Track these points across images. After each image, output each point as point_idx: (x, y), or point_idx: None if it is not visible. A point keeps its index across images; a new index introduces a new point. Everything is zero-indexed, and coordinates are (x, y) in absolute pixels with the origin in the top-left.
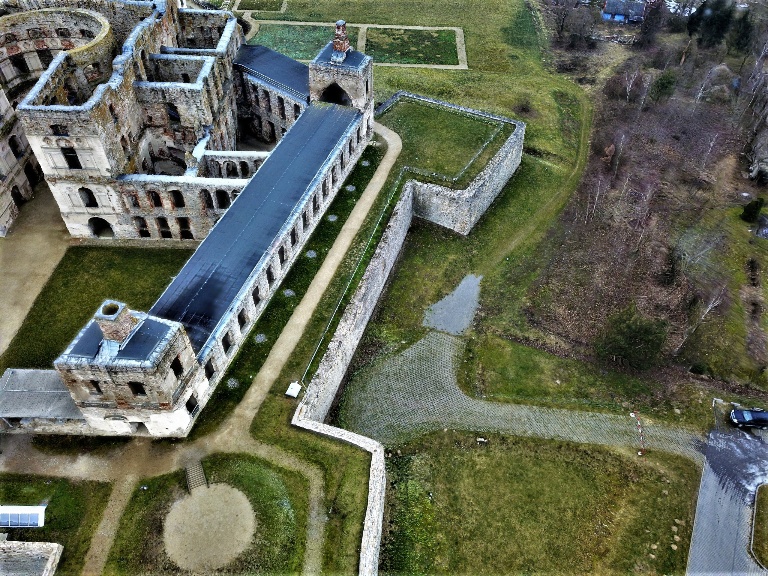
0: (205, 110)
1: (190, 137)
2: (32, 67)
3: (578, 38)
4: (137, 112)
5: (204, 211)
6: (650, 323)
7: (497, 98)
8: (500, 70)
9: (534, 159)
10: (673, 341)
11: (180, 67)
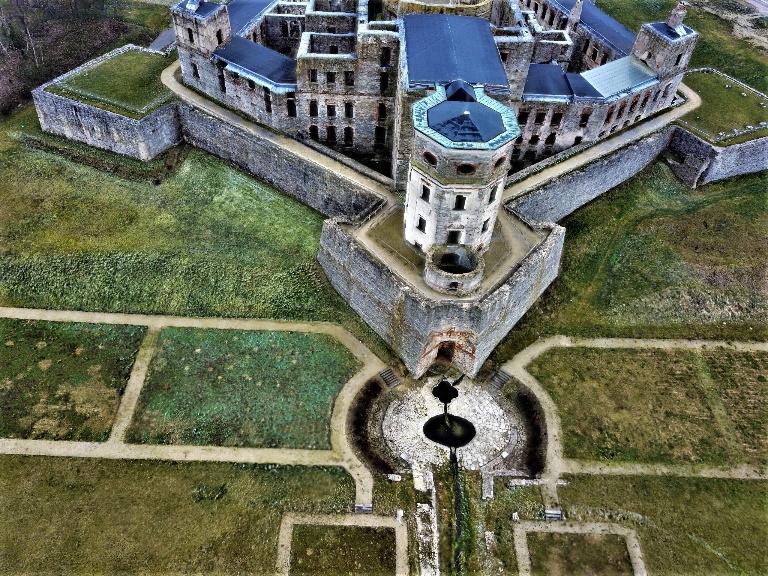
0: None
1: None
2: None
3: None
4: None
5: None
6: None
7: (3, 199)
8: None
9: (27, 133)
10: (51, 22)
11: None
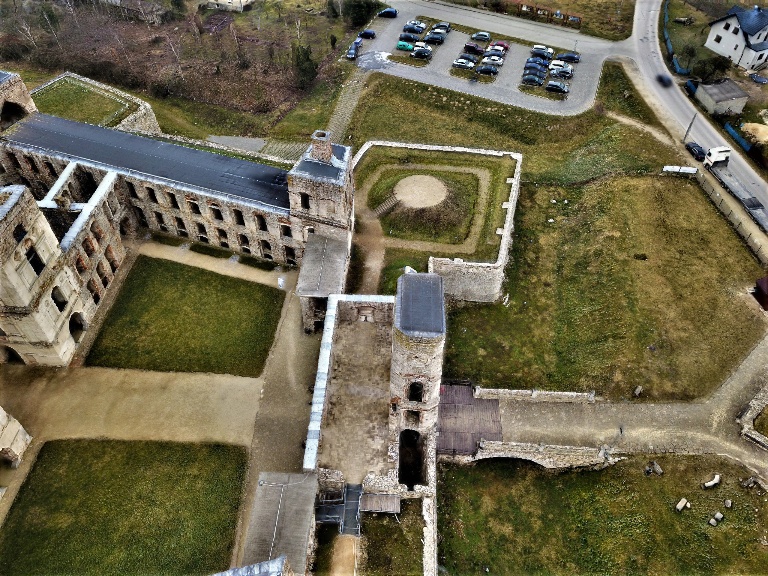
0: None
1: None
2: None
3: None
4: None
5: (111, 227)
6: (301, 50)
7: None
8: None
9: None
10: None
11: None
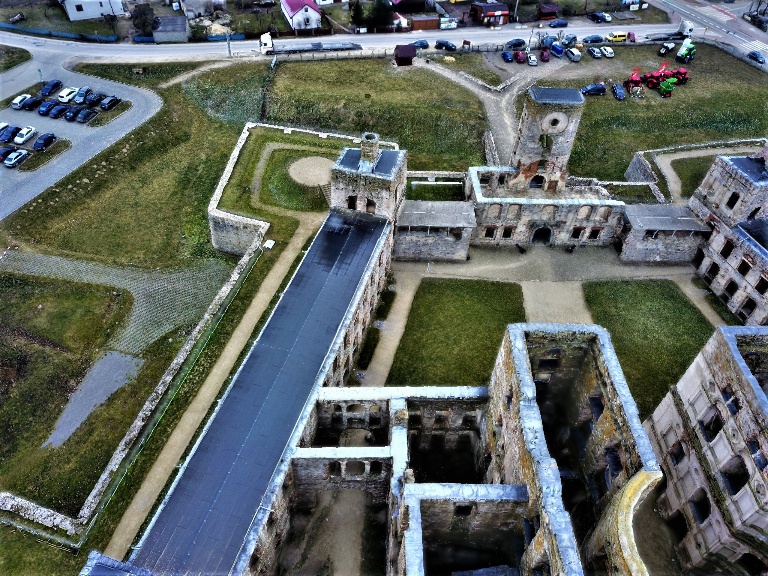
0: None
1: None
2: None
3: None
4: None
5: None
6: None
7: None
8: None
9: None
10: None
11: None
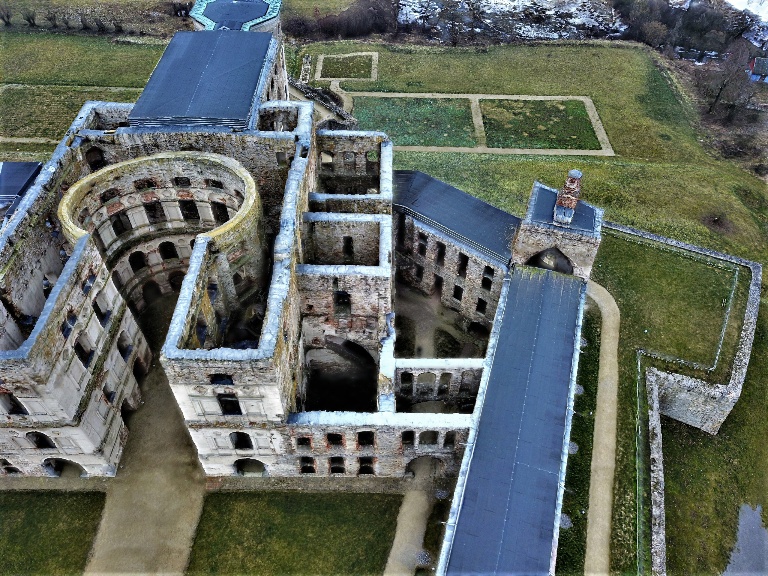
0: (389, 298)
1: (358, 324)
2: (136, 223)
3: (738, 111)
4: (297, 304)
5: (400, 450)
6: None
7: (677, 205)
8: (654, 156)
9: None
10: None
11: (343, 229)
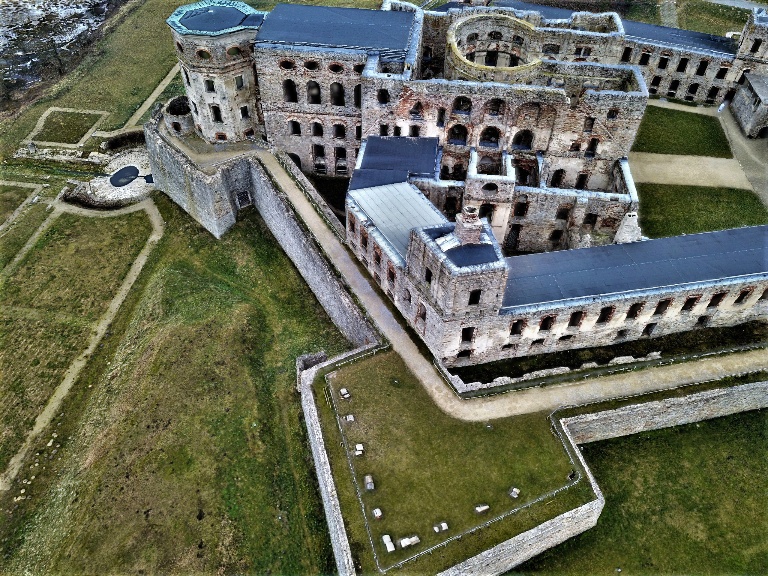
0: None
1: None
2: None
3: None
4: None
5: None
6: None
7: None
8: None
9: None
10: None
11: None
